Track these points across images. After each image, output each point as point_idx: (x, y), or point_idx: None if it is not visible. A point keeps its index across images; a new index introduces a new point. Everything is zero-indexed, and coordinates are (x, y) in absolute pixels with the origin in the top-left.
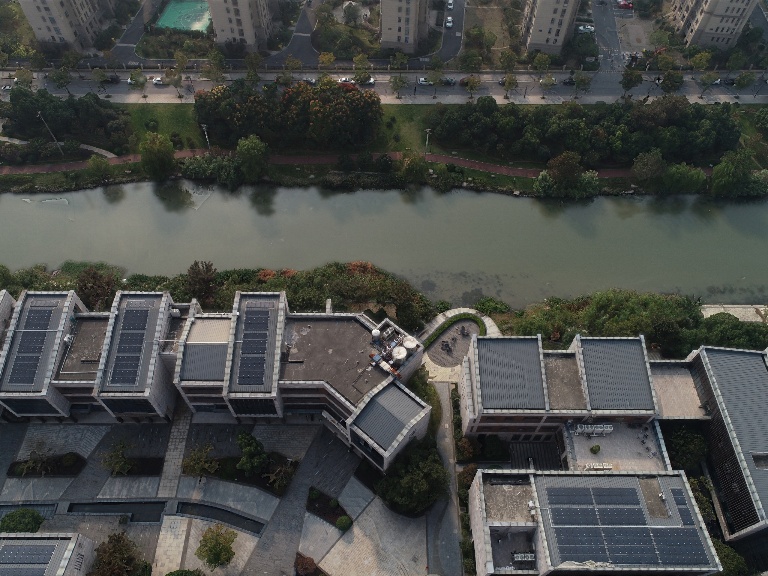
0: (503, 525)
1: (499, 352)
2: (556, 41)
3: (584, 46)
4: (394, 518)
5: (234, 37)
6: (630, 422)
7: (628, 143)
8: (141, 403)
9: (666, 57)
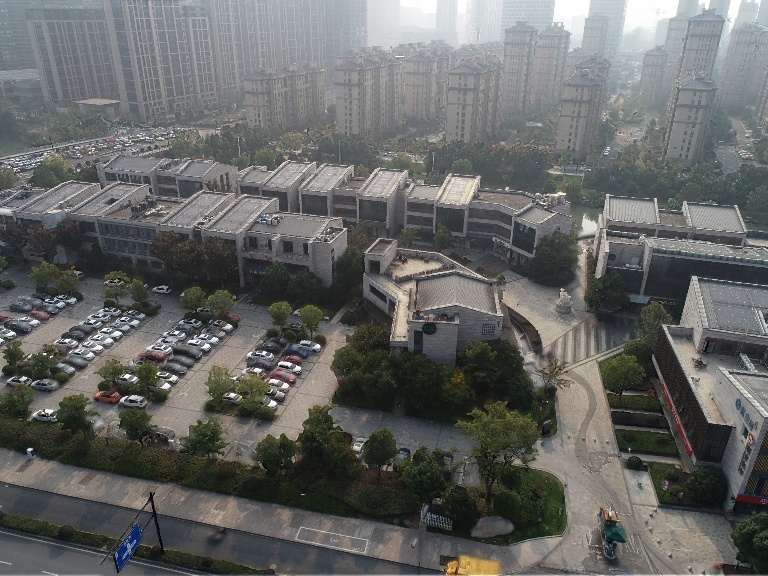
0: (619, 242)
1: (625, 202)
2: (687, 156)
3: (710, 160)
4: (536, 285)
5: (457, 139)
6: None
7: (742, 190)
8: (380, 208)
9: None
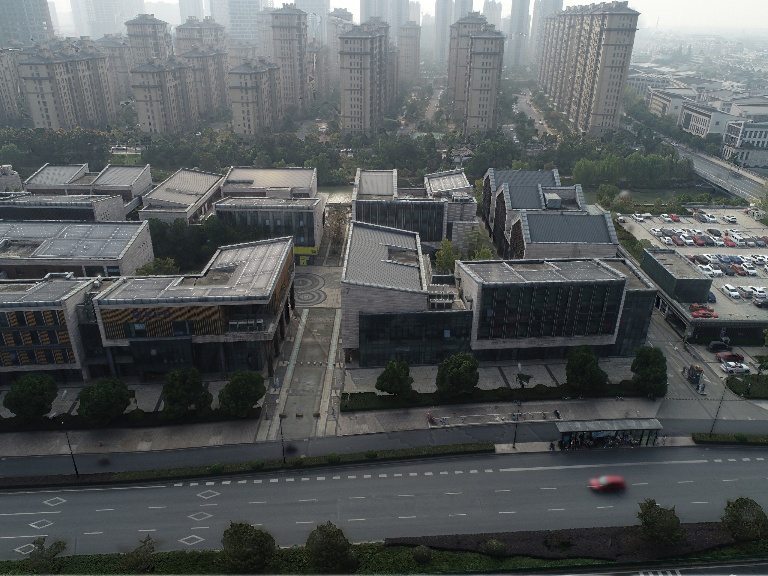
0: None
1: (57, 169)
2: (250, 132)
3: (267, 134)
4: None
5: (45, 127)
6: (122, 198)
7: None
8: None
9: (312, 135)
